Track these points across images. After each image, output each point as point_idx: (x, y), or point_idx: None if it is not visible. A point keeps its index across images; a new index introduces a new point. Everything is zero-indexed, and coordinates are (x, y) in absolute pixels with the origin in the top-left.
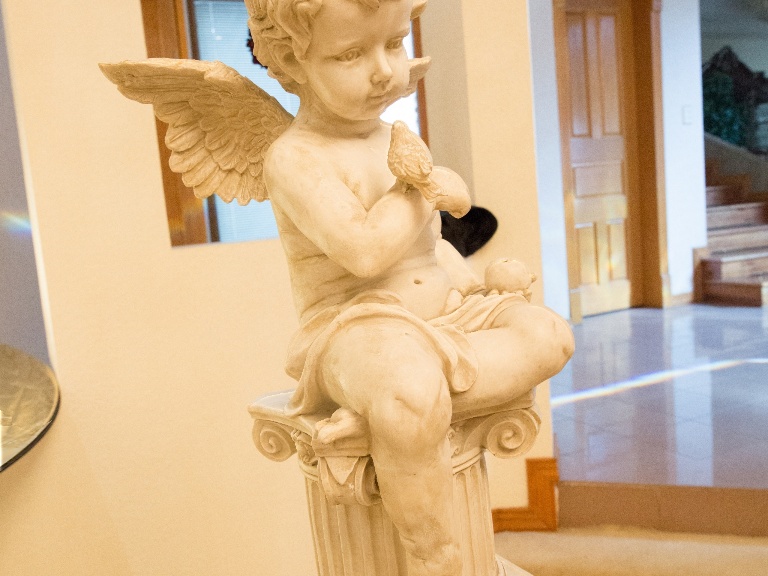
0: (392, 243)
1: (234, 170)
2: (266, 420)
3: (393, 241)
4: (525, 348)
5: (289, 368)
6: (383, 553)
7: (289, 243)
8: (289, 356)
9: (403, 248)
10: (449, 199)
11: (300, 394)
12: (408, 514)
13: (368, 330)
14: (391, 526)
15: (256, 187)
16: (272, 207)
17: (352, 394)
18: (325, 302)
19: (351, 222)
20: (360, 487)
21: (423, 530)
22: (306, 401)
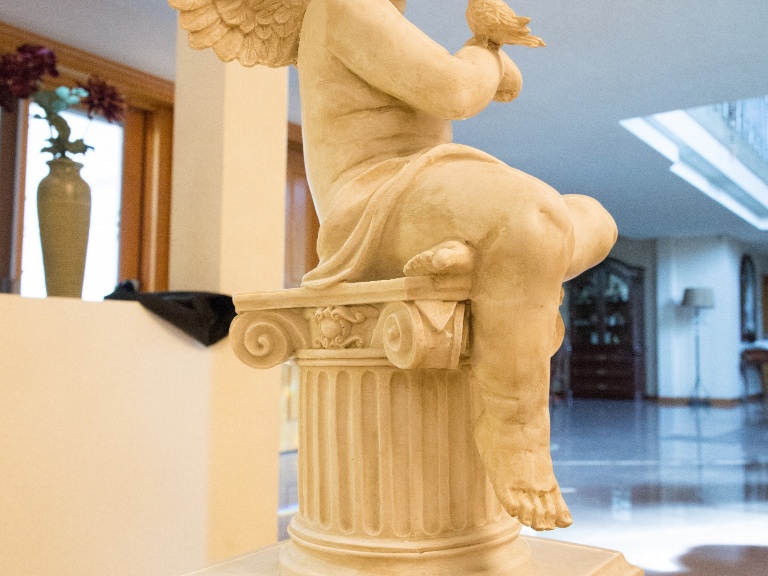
0: (488, 84)
1: (237, 28)
2: (262, 310)
3: (488, 83)
4: (588, 223)
5: (332, 226)
6: (433, 449)
7: (334, 93)
8: (336, 210)
9: (490, 97)
10: (511, 74)
11: (348, 254)
12: (522, 360)
13: (472, 162)
14: (446, 413)
15: (264, 50)
16: (312, 55)
17: (473, 216)
18: (375, 160)
19: (448, 55)
20: (461, 334)
21: (532, 382)
22: (361, 259)
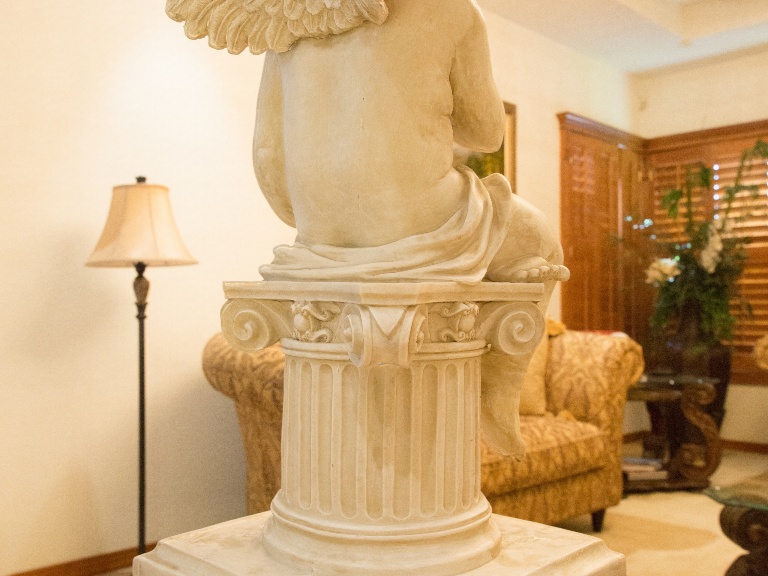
0: None
1: None
2: None
3: None
4: None
5: (476, 227)
6: None
7: (448, 93)
8: None
9: None
10: None
11: None
12: None
13: None
14: None
15: None
16: (440, 44)
17: None
18: None
19: None
20: None
21: None
22: None
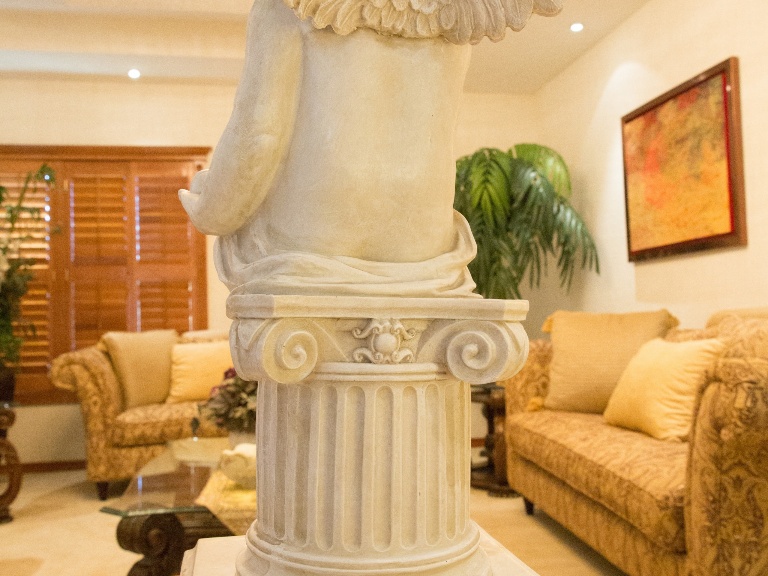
0: None
1: None
2: None
3: None
4: None
5: None
6: None
7: None
8: (471, 237)
9: None
10: None
11: None
12: None
13: None
14: None
15: None
16: None
17: None
18: None
19: None
20: None
21: None
22: None
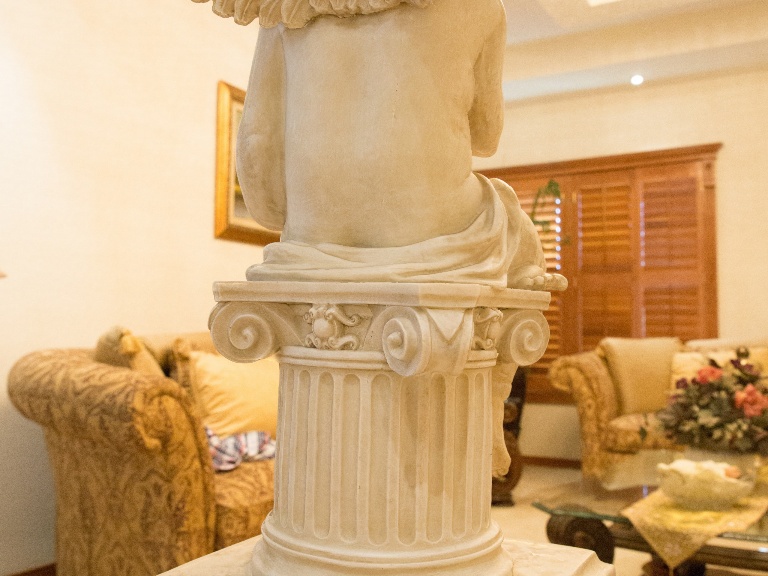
0: None
1: None
2: (475, 307)
3: None
4: None
5: None
6: None
7: None
8: None
9: None
10: None
11: None
12: None
13: None
14: None
15: None
16: (473, 37)
17: None
18: None
19: None
20: None
21: None
22: None
